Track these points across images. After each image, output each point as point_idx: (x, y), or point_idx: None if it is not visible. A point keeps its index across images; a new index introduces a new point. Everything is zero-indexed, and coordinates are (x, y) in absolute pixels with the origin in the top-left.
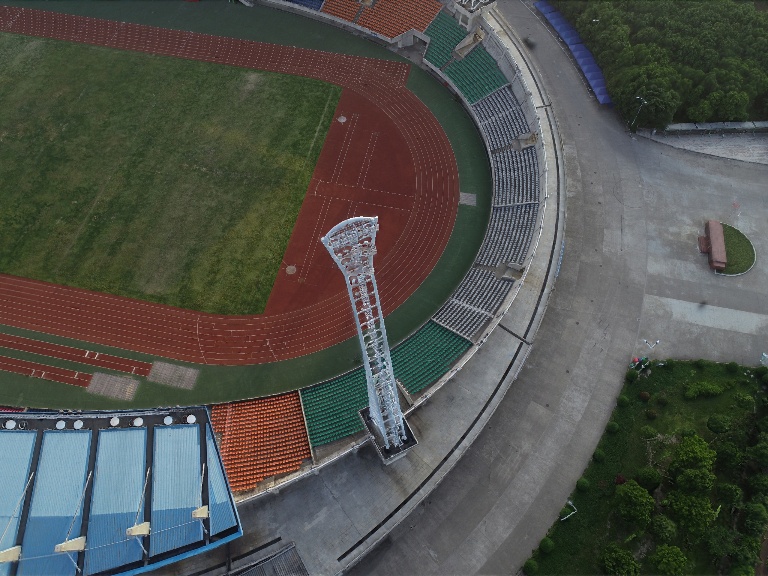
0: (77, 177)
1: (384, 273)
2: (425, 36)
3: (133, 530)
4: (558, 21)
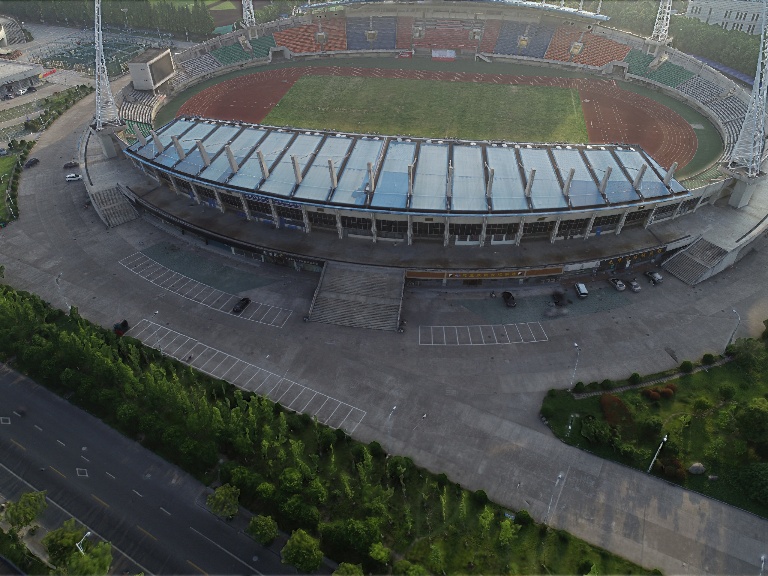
0: (427, 124)
1: (664, 154)
2: (624, 63)
3: None
4: (704, 59)
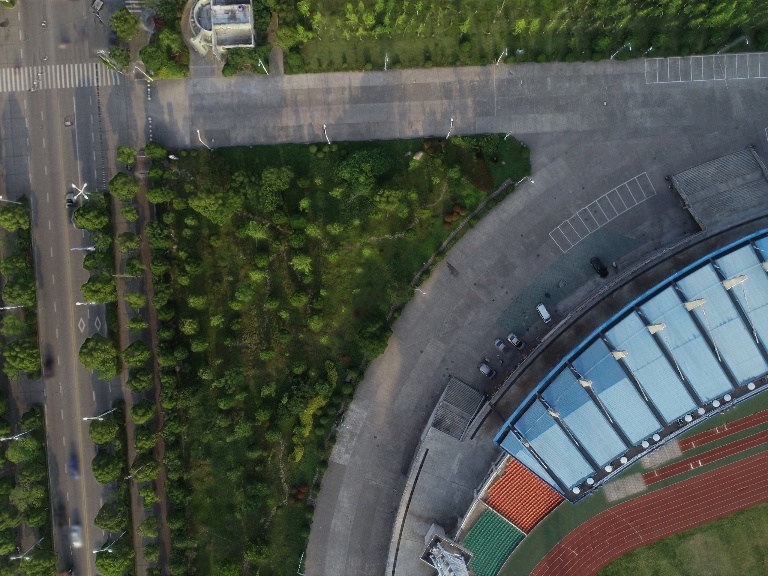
0: None
1: None
2: None
3: (556, 415)
4: None
